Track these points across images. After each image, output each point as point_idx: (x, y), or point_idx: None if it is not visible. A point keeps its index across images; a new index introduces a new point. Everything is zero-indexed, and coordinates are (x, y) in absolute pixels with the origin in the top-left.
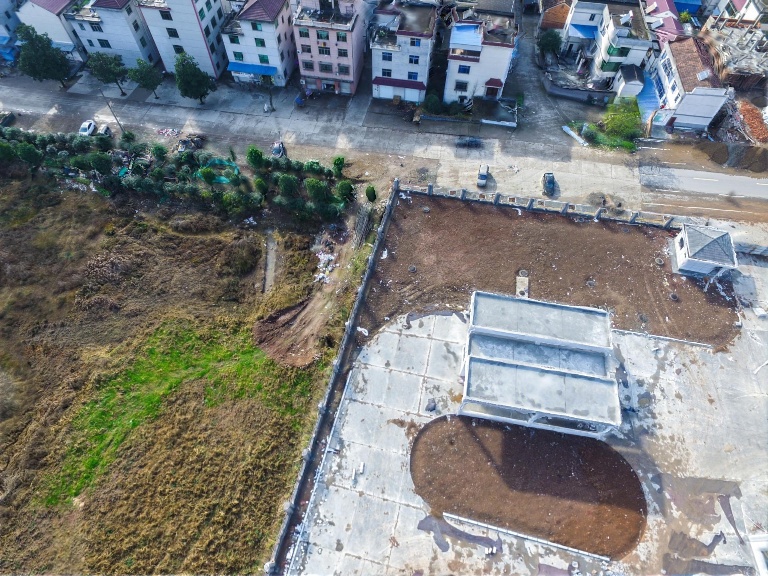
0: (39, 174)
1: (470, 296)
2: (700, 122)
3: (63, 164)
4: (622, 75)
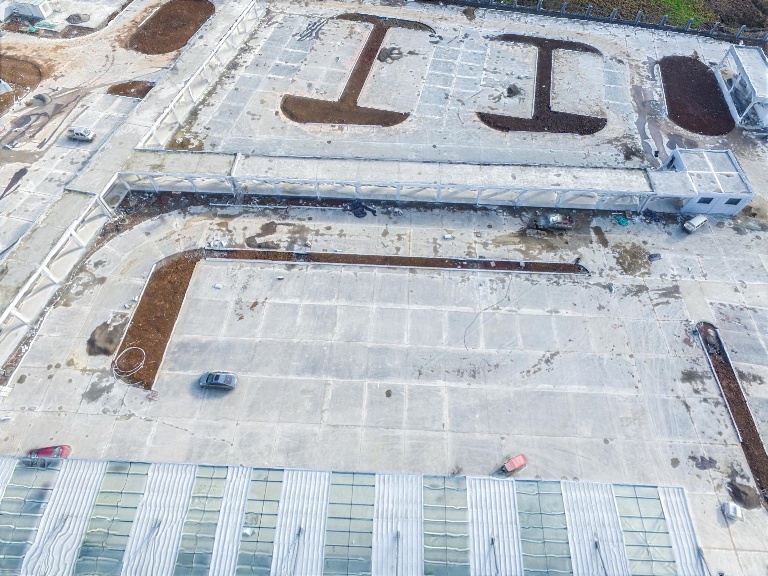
0: None
1: None
2: None
3: None
4: None
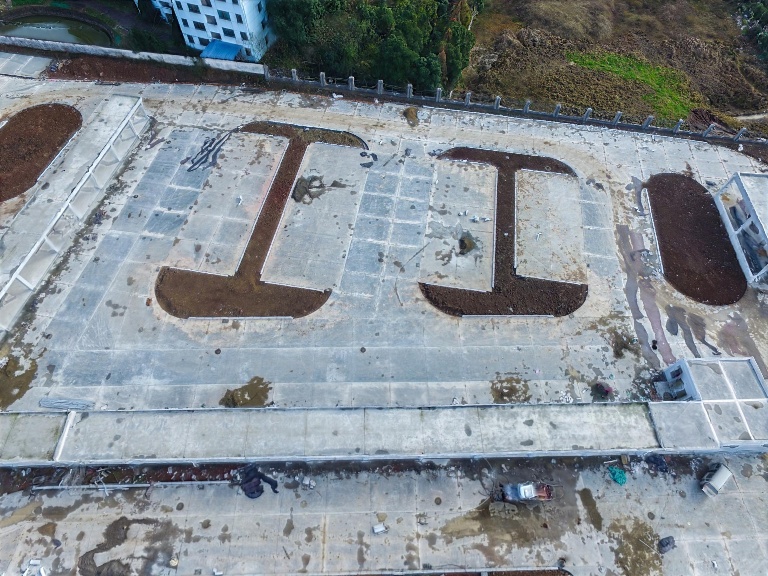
0: (735, 4)
1: None
2: None
3: (752, 7)
4: None
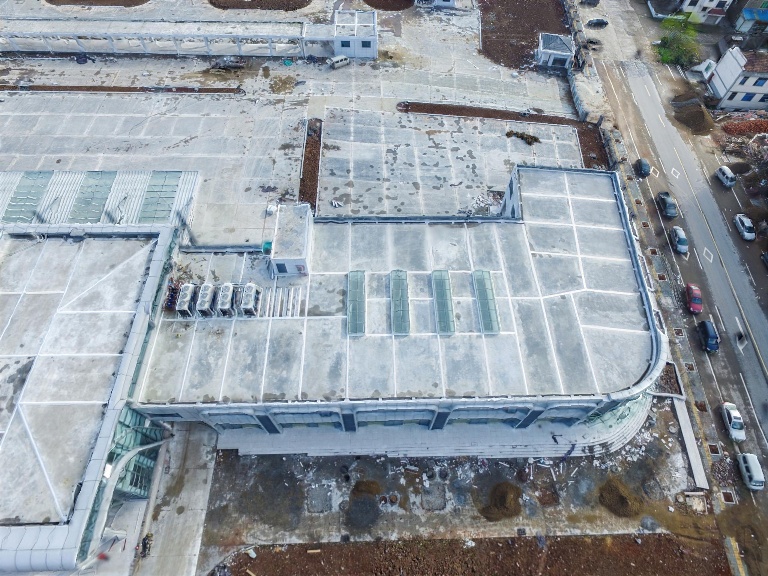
0: None
1: None
2: None
3: None
4: None
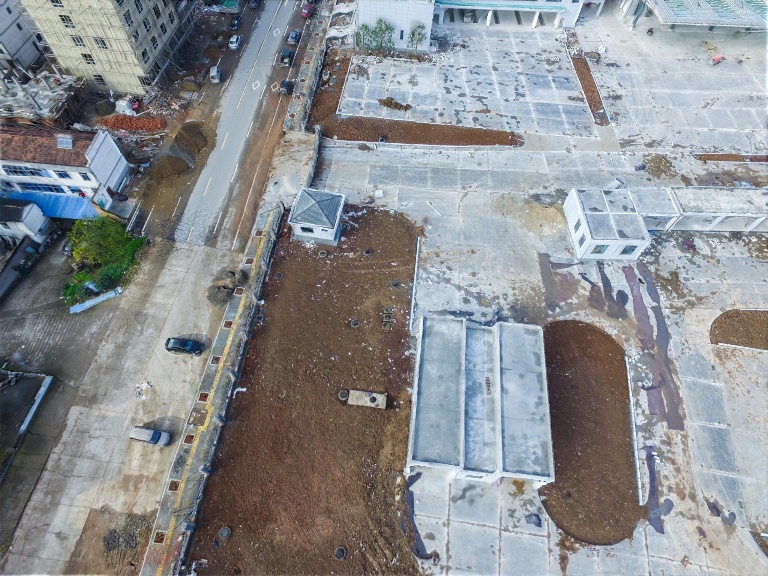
0: None
1: (380, 466)
2: (121, 167)
3: None
4: (2, 222)
